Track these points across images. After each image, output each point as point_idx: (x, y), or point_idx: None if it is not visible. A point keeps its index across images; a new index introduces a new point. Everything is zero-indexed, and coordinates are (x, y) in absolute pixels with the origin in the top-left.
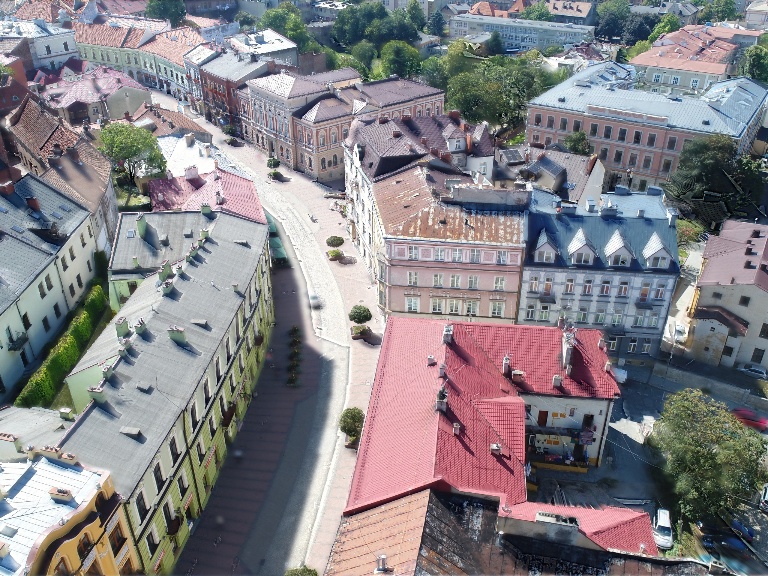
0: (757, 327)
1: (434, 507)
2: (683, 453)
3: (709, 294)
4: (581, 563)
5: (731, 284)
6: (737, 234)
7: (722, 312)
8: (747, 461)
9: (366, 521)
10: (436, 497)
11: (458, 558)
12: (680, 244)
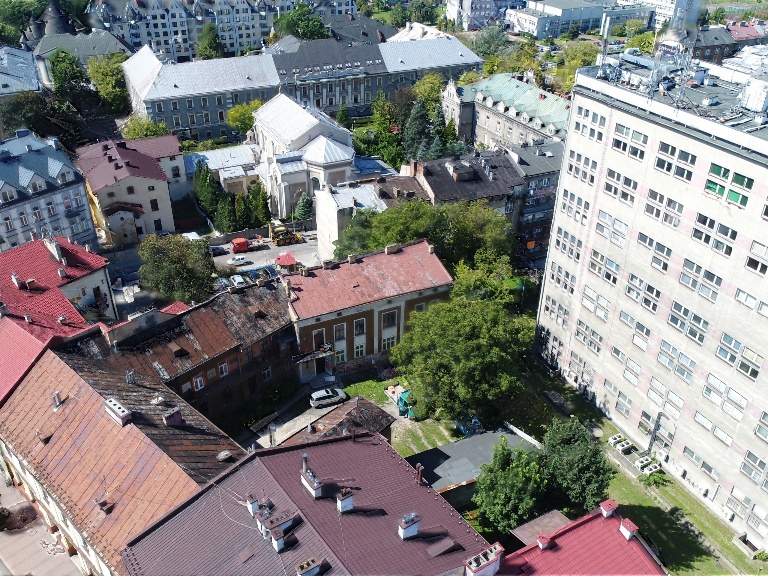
0: (148, 205)
1: (61, 356)
2: (169, 273)
3: (105, 196)
4: (169, 330)
5: (116, 182)
6: (92, 154)
7: (121, 205)
8: (204, 255)
9: (13, 405)
10: (57, 351)
11: (101, 371)
12: (72, 159)
